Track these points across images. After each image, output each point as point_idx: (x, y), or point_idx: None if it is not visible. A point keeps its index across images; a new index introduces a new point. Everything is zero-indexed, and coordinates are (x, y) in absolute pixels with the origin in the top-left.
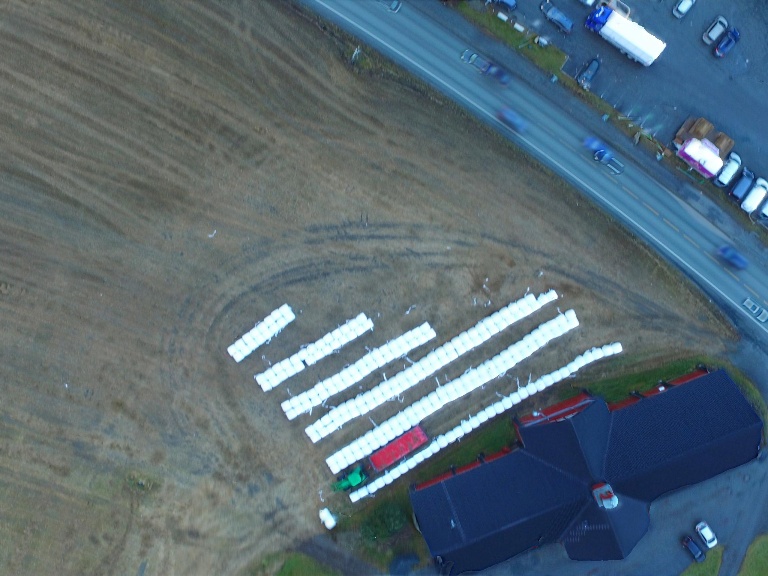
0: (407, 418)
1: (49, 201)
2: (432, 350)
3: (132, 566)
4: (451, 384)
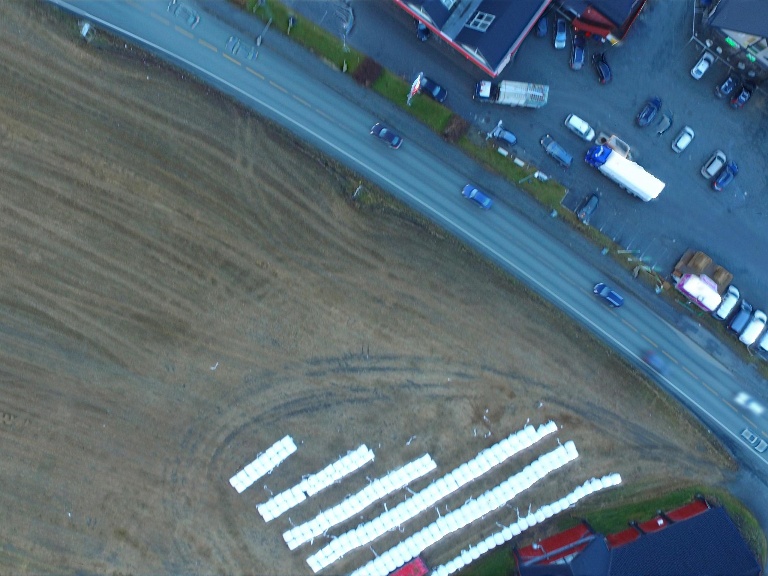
0: (408, 549)
1: (52, 334)
2: (433, 481)
3: None
4: (451, 516)
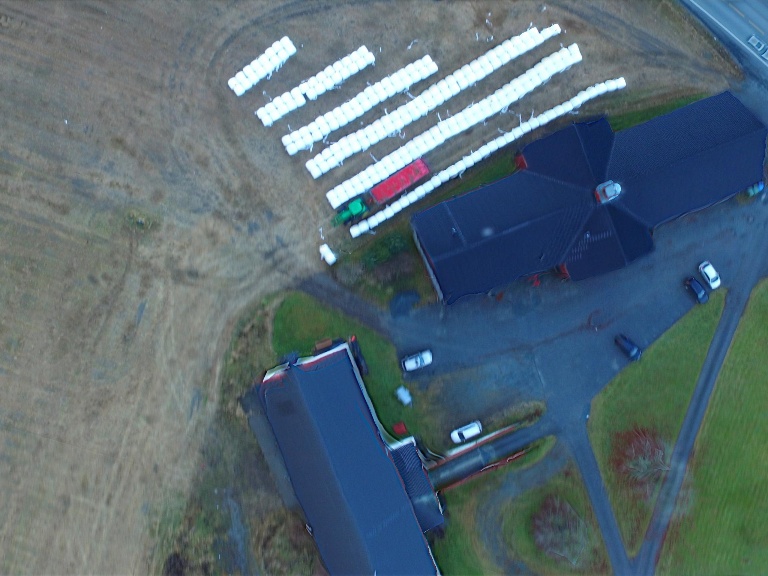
0: (408, 151)
1: None
2: (434, 83)
3: (131, 307)
4: (453, 117)
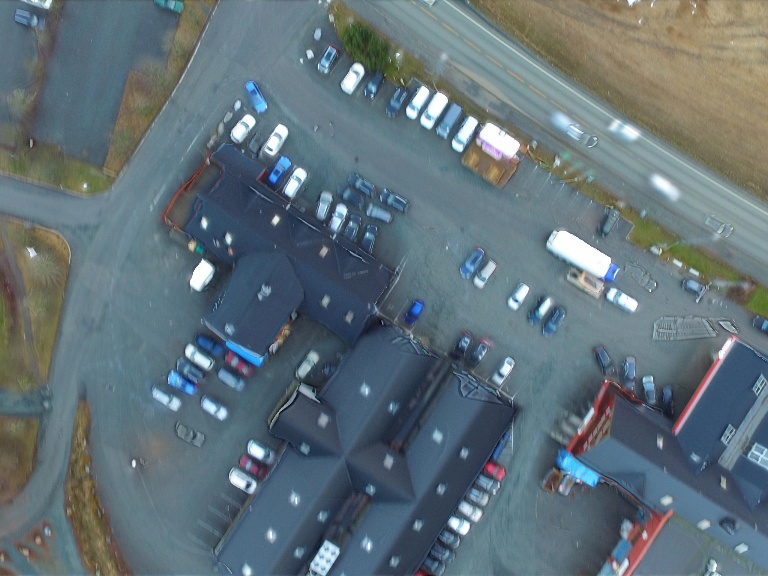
0: None
1: None
2: None
3: None
4: None
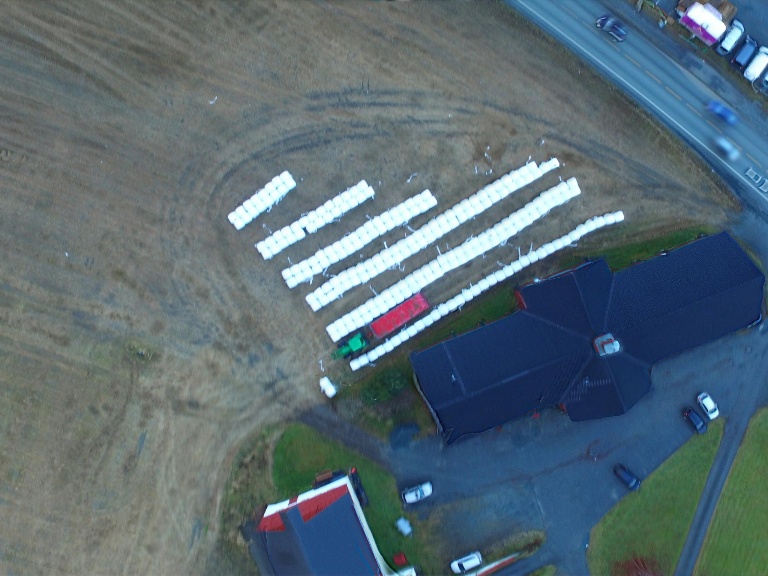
0: (408, 286)
1: (50, 66)
2: (433, 218)
3: (132, 437)
4: (452, 251)
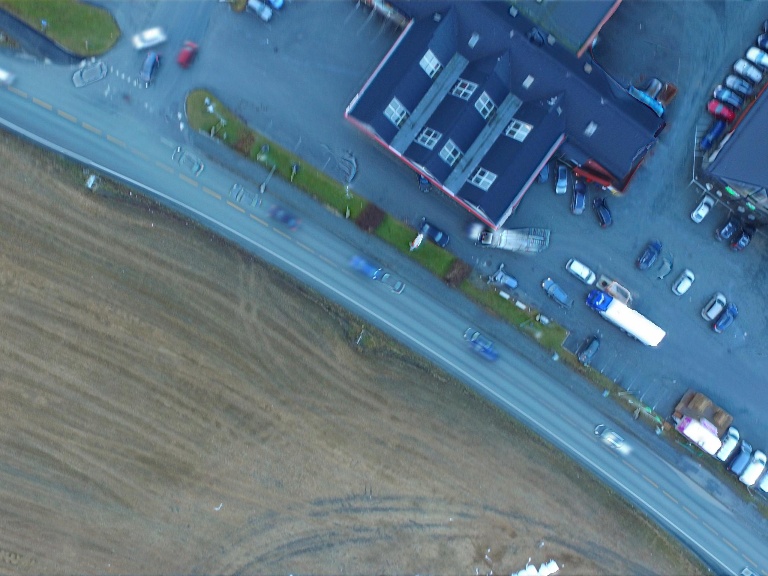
0: None
1: (58, 476)
2: None
3: None
4: None
